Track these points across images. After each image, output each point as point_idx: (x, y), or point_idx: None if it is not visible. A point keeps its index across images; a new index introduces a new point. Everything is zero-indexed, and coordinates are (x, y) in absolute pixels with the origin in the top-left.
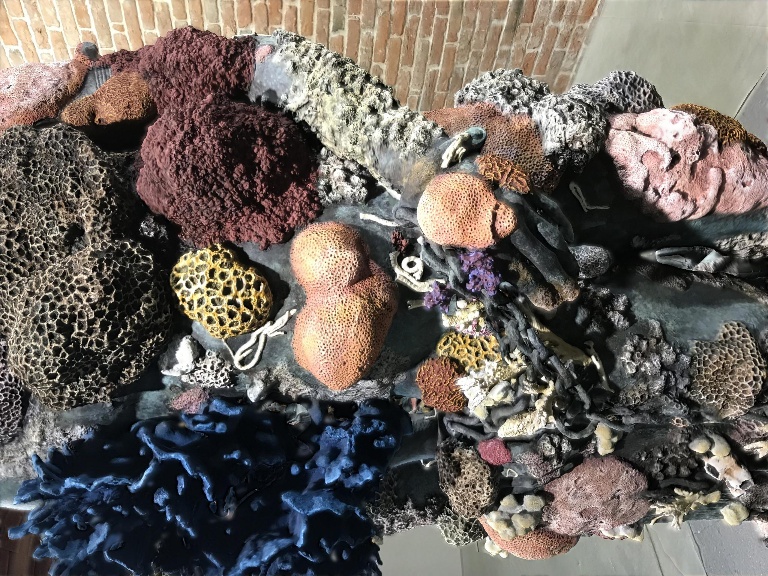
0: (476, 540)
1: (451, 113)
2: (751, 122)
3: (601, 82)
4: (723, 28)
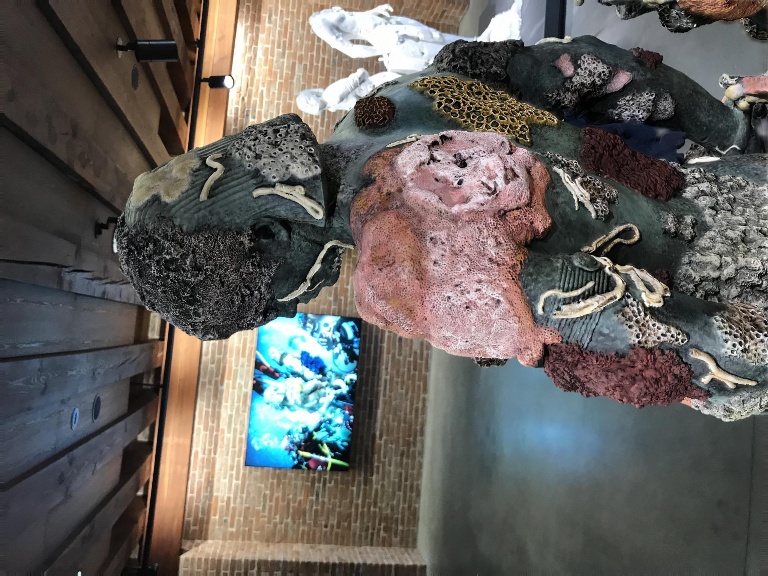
0: None
1: None
2: None
3: None
4: None
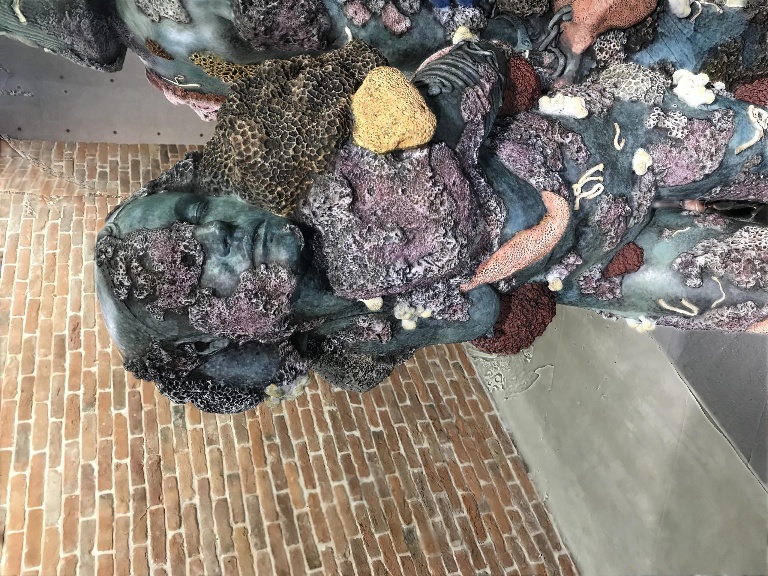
0: (656, 75)
1: None
2: (721, 404)
3: None
4: (673, 479)
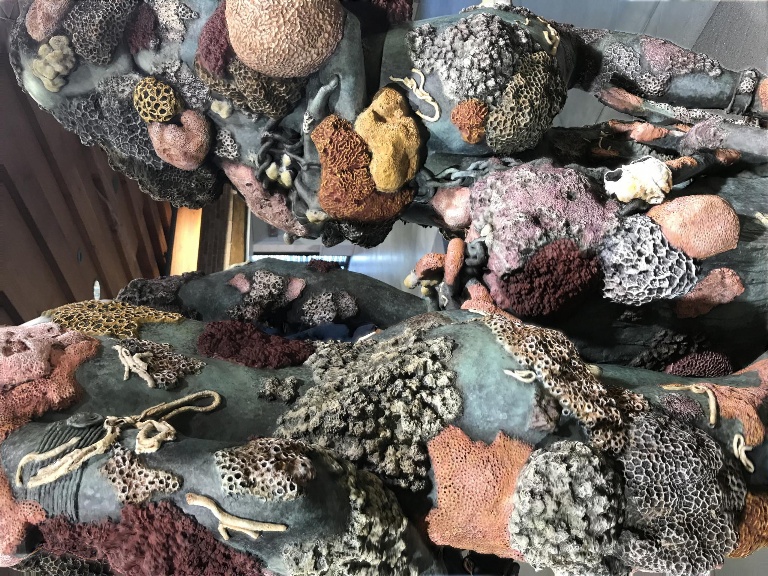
0: None
1: (485, 545)
2: None
3: (665, 568)
4: None
